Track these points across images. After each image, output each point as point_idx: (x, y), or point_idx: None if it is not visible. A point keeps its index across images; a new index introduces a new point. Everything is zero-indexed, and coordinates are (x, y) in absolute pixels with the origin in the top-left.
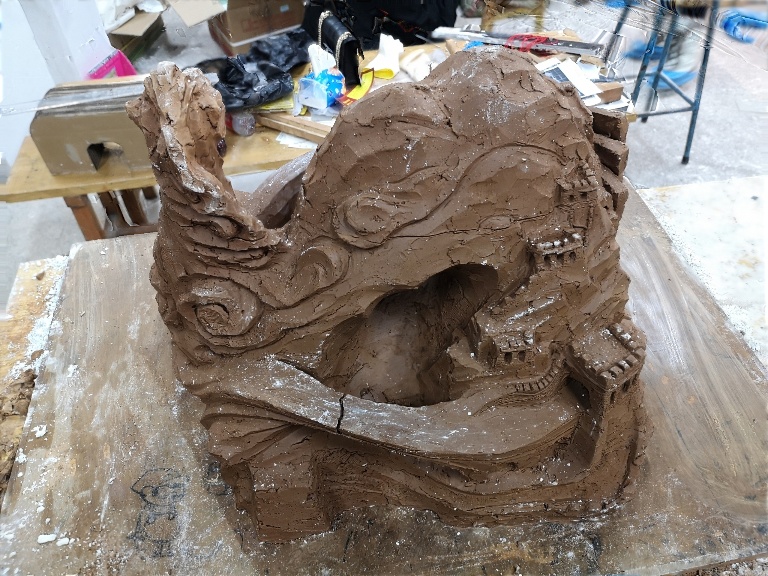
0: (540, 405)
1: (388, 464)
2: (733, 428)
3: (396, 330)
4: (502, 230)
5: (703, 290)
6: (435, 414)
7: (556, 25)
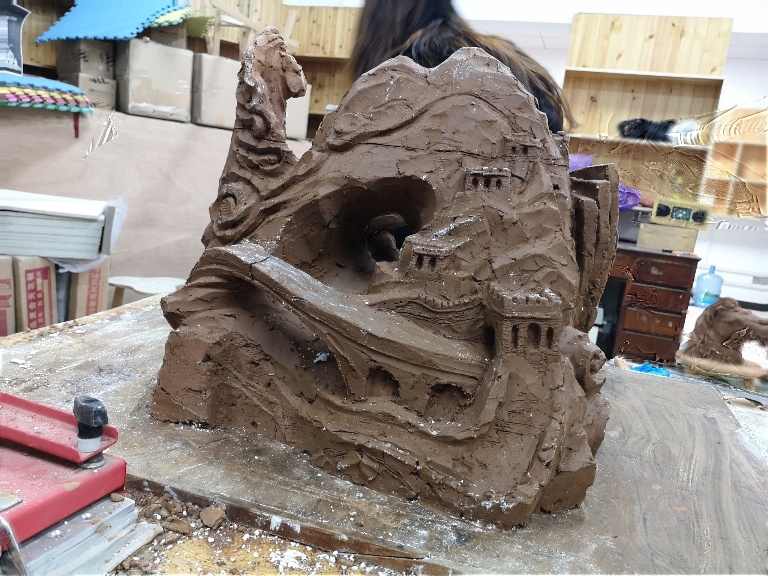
0: (444, 337)
1: (292, 385)
2: (727, 544)
3: (361, 290)
4: (444, 152)
5: (760, 460)
6: (337, 294)
7: (745, 385)
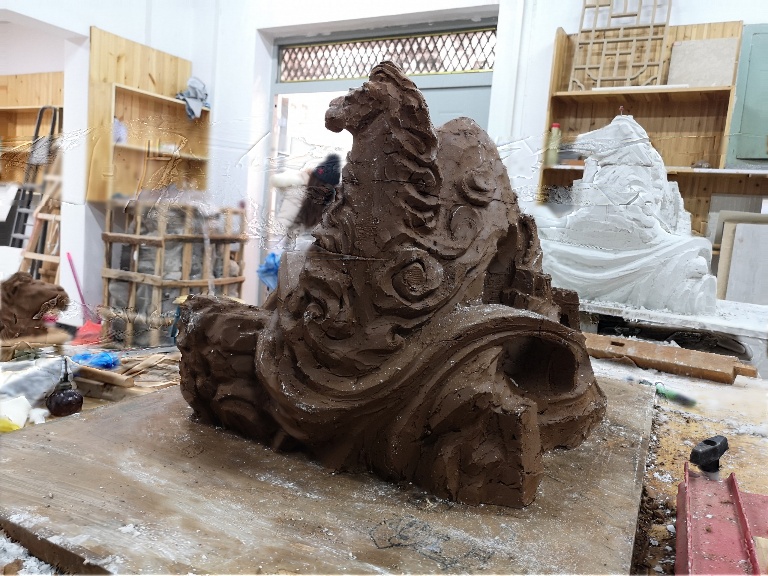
0: None
1: None
2: None
3: None
4: None
5: None
6: None
7: (122, 345)
